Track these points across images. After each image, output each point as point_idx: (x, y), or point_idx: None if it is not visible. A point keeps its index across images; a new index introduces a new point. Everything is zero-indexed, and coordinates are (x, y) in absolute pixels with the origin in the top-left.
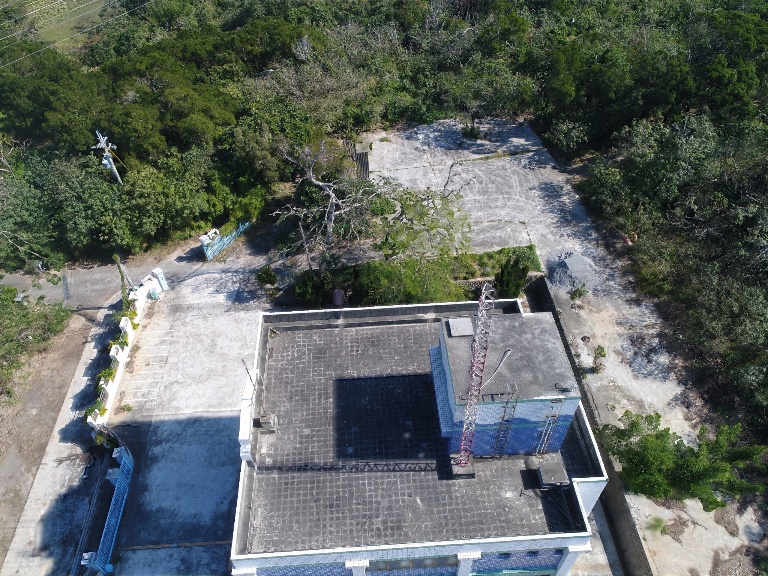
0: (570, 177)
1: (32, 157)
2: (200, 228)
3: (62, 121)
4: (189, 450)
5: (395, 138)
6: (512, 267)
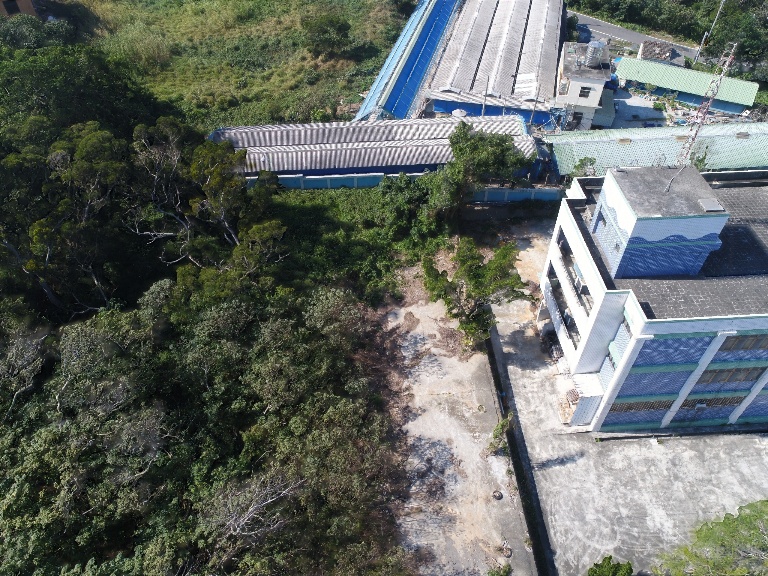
0: None
1: None
2: None
3: None
4: None
5: None
6: None
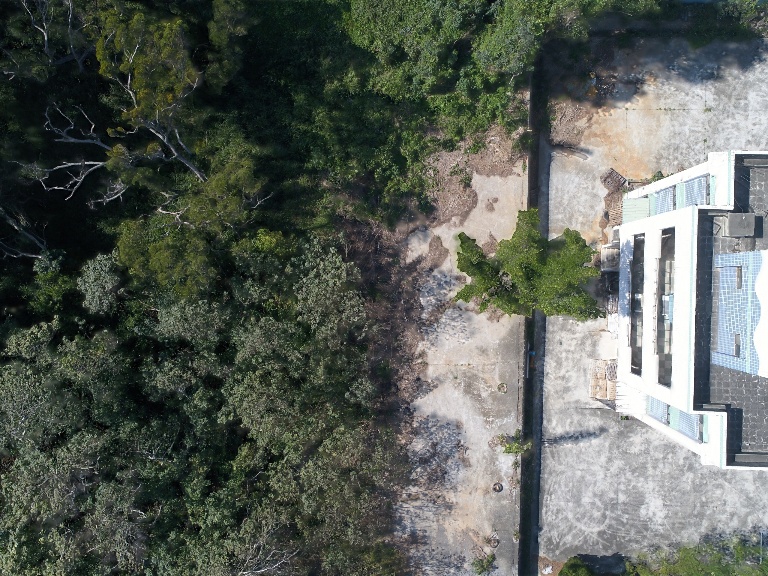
0: None
1: None
2: None
3: None
4: None
5: None
6: None
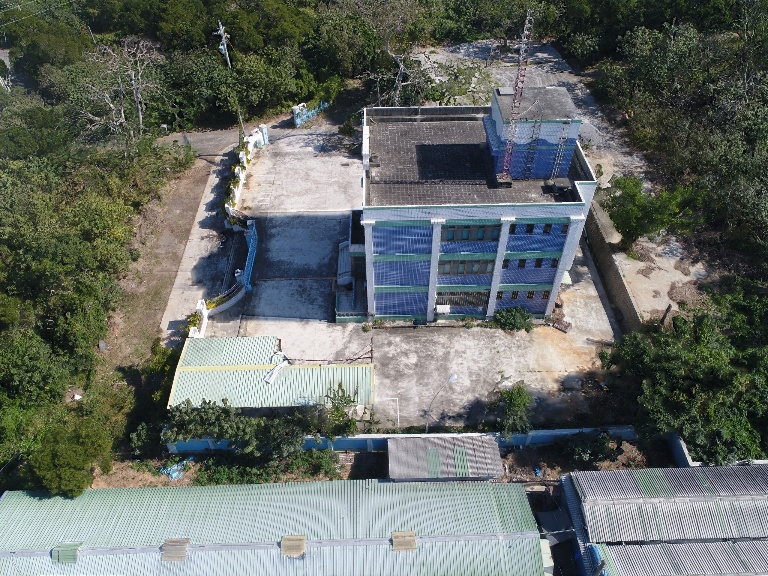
0: (583, 78)
1: None
2: (289, 107)
3: (174, 29)
4: (297, 231)
5: (442, 51)
6: None
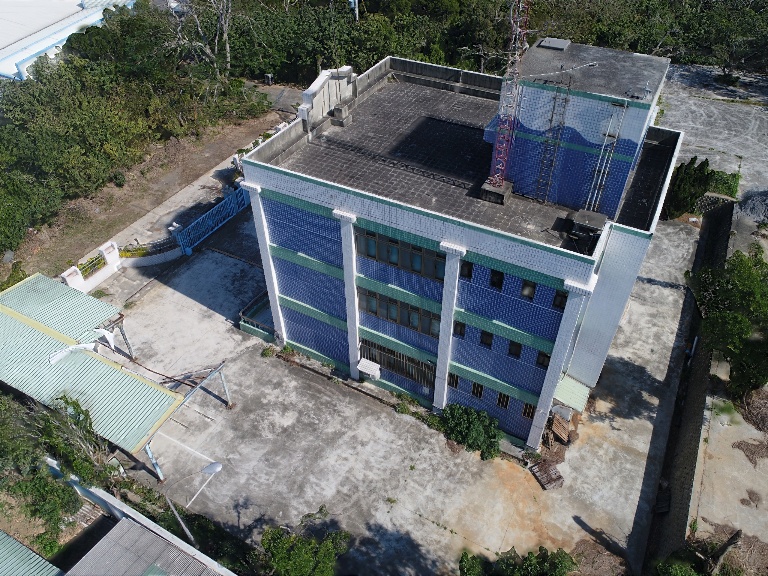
0: None
1: (306, 5)
2: None
3: None
4: None
5: None
6: (695, 170)
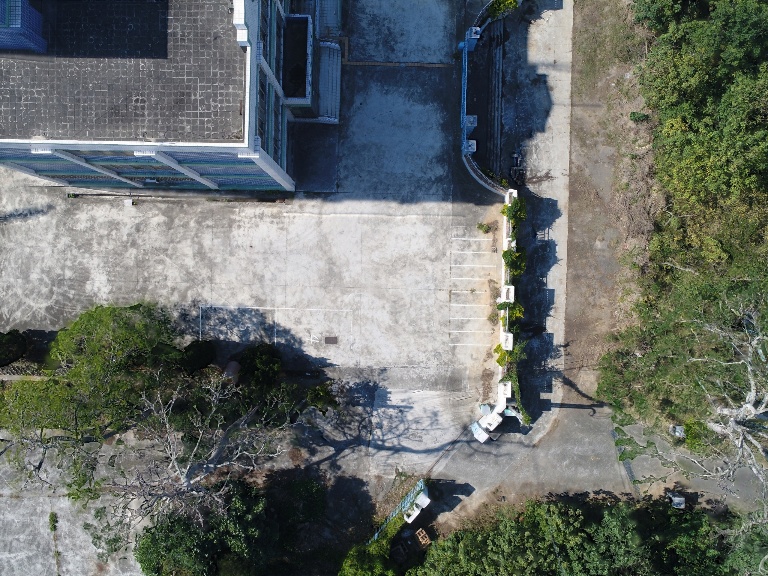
0: None
1: None
2: None
3: None
4: (404, 167)
5: None
6: None
